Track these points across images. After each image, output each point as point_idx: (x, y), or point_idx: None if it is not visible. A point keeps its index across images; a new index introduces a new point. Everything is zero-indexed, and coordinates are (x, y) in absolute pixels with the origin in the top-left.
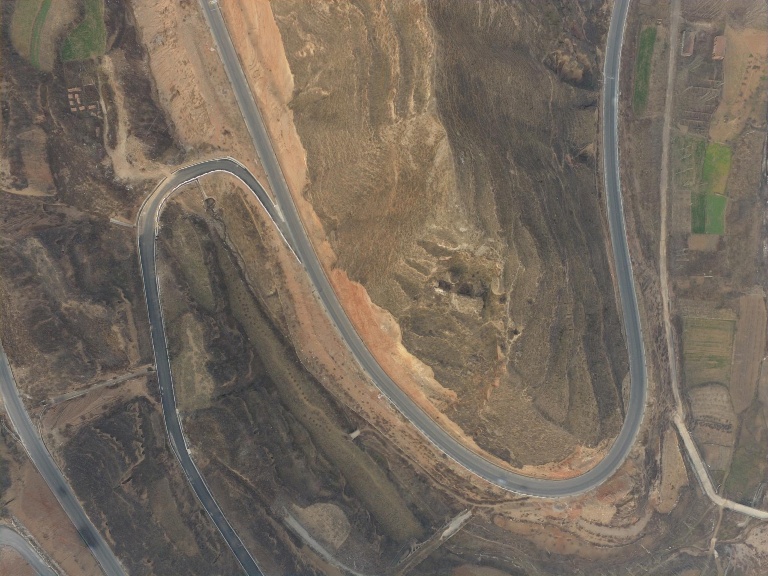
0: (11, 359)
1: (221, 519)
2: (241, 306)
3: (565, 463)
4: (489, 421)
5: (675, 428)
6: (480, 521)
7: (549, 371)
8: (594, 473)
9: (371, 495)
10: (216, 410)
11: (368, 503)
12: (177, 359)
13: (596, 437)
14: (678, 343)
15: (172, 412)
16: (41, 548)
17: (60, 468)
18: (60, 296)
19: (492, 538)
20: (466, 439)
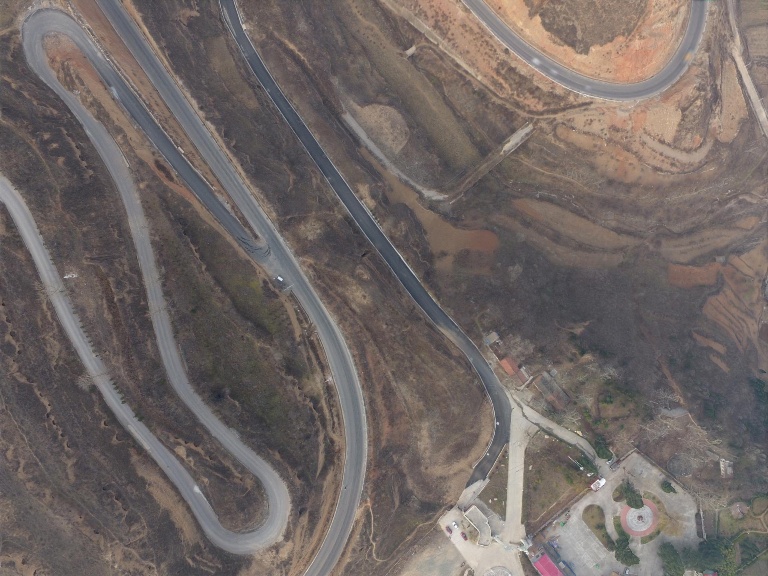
0: None
1: (279, 95)
2: None
3: (634, 35)
4: None
5: (733, 60)
6: (540, 141)
7: None
8: (658, 79)
9: (427, 119)
10: None
11: (424, 127)
12: None
13: None
14: None
15: None
16: (99, 40)
17: None
18: None
19: (552, 165)
20: (529, 29)
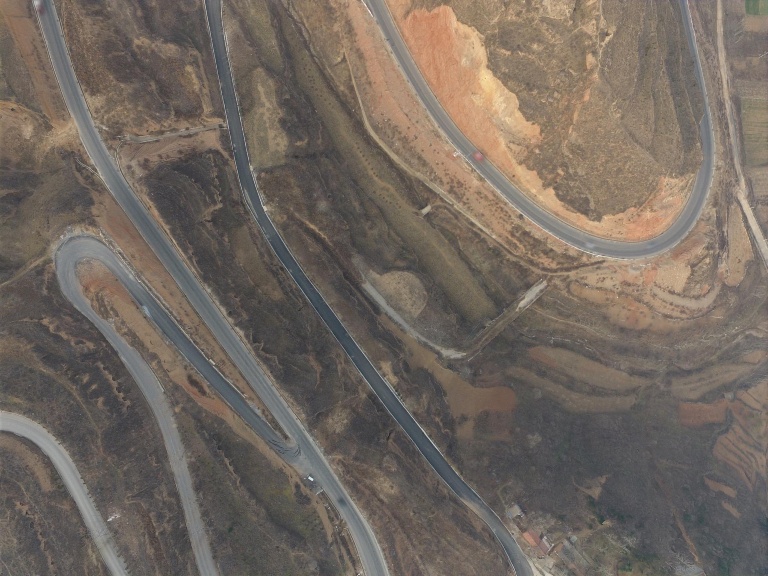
0: (86, 87)
1: (301, 275)
2: (307, 78)
3: (645, 207)
4: (573, 156)
5: (739, 204)
6: (554, 294)
7: (635, 90)
8: (667, 235)
9: (443, 274)
10: (291, 166)
11: (440, 282)
12: (249, 115)
13: (680, 165)
14: (738, 121)
15: (246, 169)
16: (130, 263)
17: (141, 200)
18: (132, 32)
19: (565, 315)
20: (543, 196)
